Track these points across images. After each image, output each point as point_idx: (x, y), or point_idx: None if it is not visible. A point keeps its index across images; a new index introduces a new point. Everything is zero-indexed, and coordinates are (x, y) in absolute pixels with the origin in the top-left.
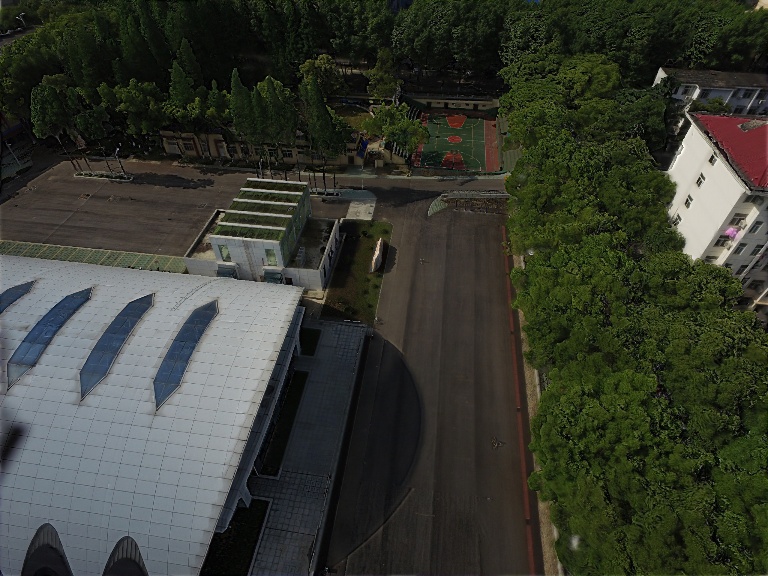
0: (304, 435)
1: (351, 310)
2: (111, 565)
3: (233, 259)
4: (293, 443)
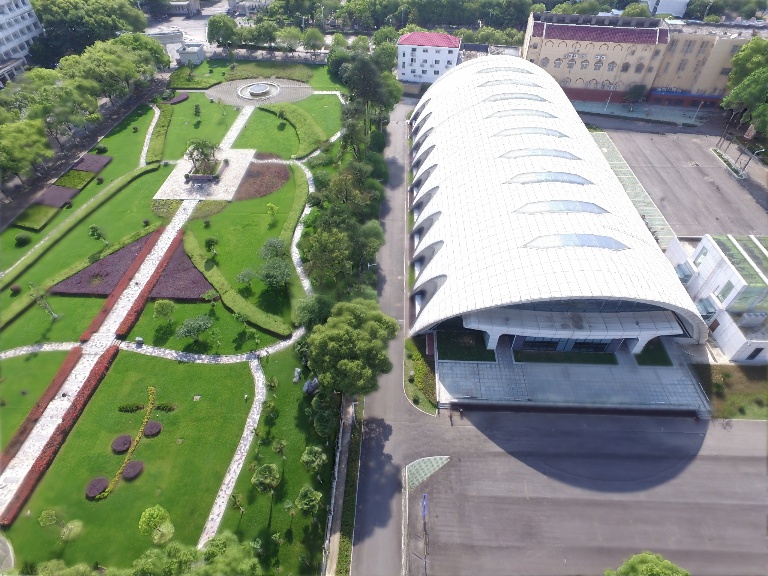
0: (557, 374)
1: (719, 389)
2: (432, 280)
3: (701, 267)
4: (546, 367)
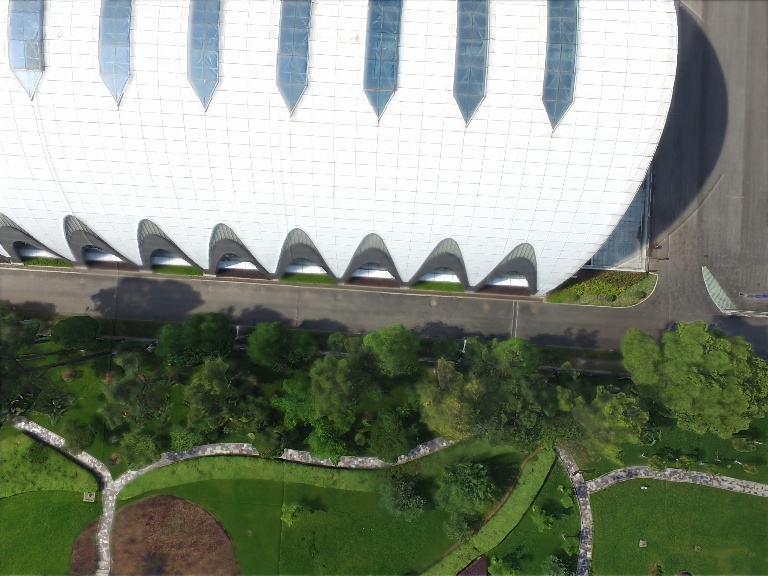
0: None
1: None
2: (504, 262)
3: None
4: None
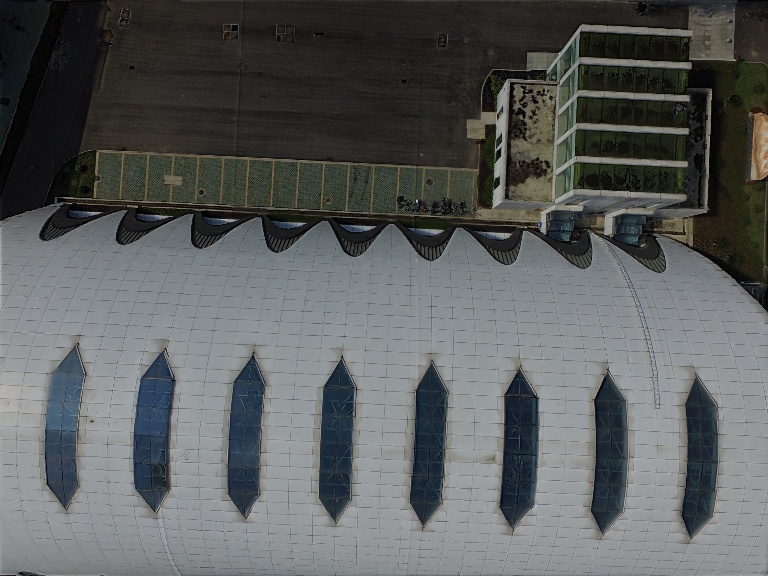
0: None
1: (739, 261)
2: None
3: (584, 204)
4: None
